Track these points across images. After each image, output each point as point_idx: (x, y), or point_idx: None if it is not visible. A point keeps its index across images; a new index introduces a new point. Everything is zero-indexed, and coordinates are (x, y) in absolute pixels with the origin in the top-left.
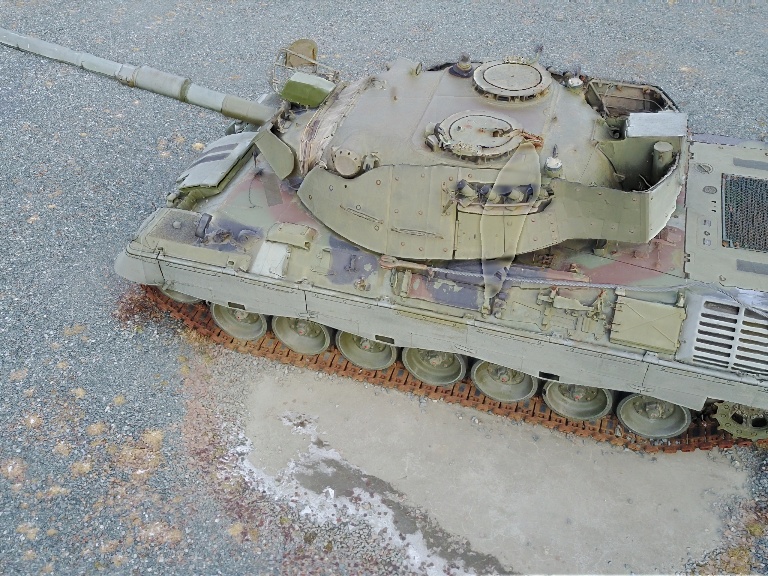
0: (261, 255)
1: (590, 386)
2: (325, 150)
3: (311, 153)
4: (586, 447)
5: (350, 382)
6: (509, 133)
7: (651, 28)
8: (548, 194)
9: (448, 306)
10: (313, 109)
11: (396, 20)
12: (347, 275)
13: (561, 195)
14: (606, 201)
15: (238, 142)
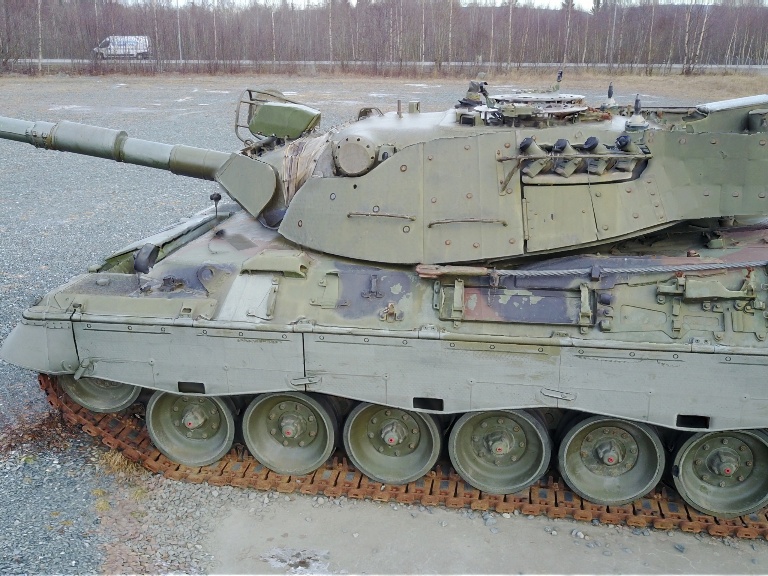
0: (233, 294)
1: (759, 427)
2: (319, 160)
3: (299, 169)
4: (760, 553)
5: (368, 505)
6: None
7: None
8: (643, 152)
9: (525, 325)
10: (293, 140)
11: None
12: (366, 304)
13: (660, 153)
14: (722, 153)
15: (186, 221)
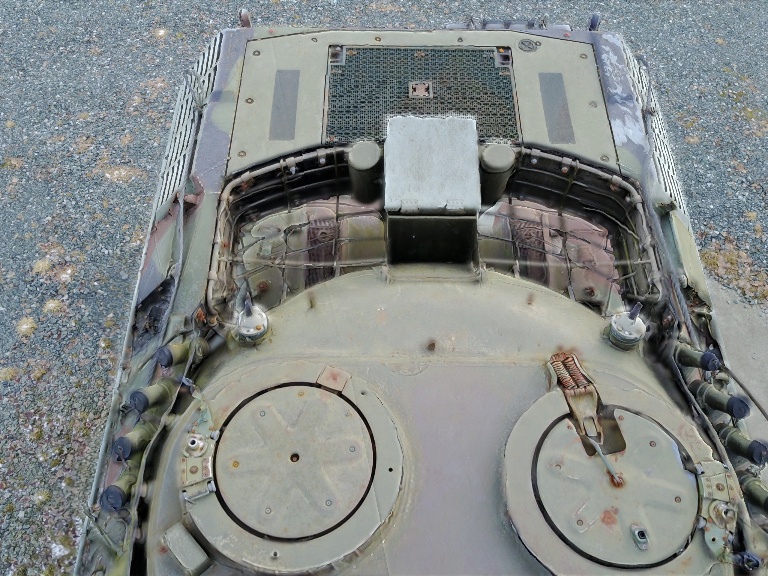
0: None
1: None
2: None
3: None
4: None
5: None
6: (581, 423)
7: None
8: None
9: None
10: None
11: None
12: None
13: None
14: None
15: None
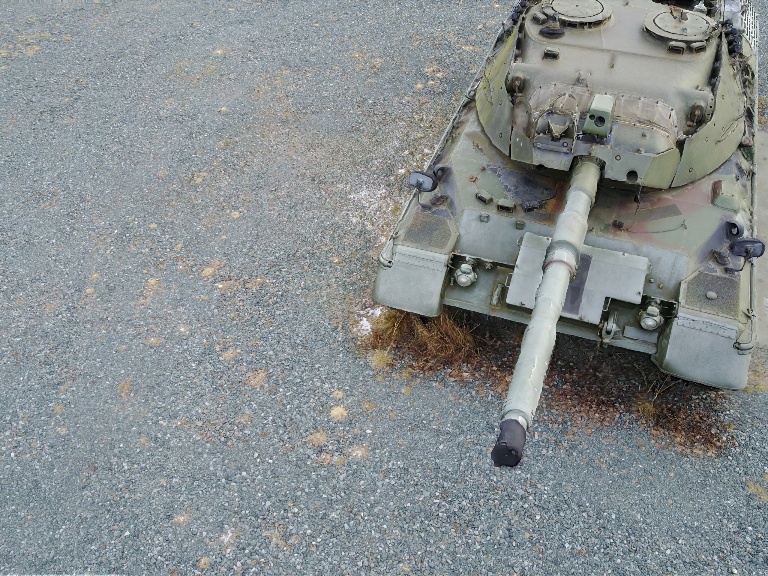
0: None
1: None
2: None
3: None
4: None
5: None
6: None
7: (123, 54)
8: None
9: None
10: (612, 126)
11: (3, 219)
12: None
13: None
14: None
15: None
